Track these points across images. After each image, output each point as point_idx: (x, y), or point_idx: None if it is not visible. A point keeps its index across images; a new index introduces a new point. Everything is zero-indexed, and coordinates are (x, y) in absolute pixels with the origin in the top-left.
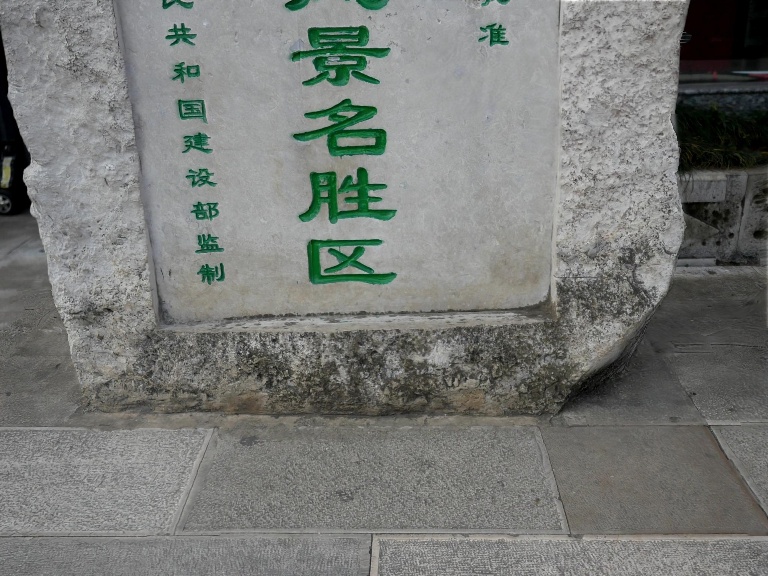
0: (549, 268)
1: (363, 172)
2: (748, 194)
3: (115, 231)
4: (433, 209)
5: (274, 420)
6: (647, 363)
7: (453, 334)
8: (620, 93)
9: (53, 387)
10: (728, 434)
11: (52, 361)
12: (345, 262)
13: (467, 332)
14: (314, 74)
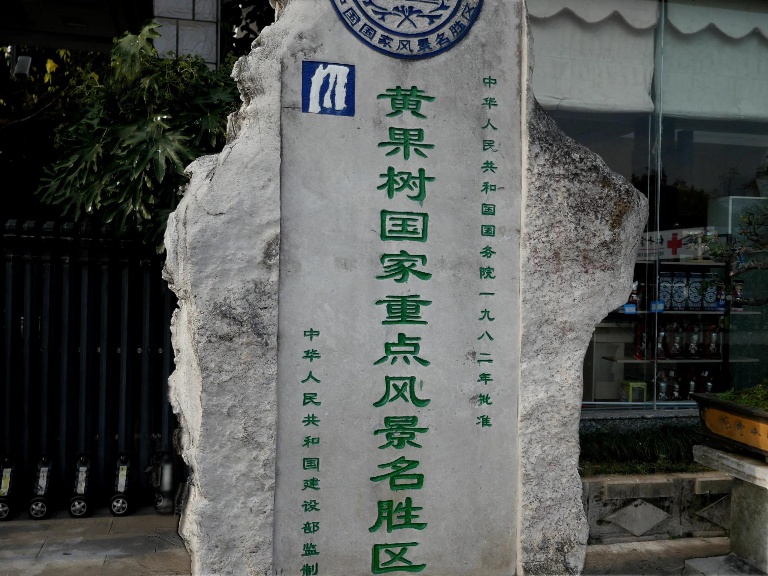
0: (515, 556)
1: (409, 500)
2: (590, 495)
3: (253, 544)
4: (449, 522)
5: None
6: None
7: None
8: (551, 453)
9: None
10: None
11: None
12: (395, 558)
13: None
14: (385, 442)
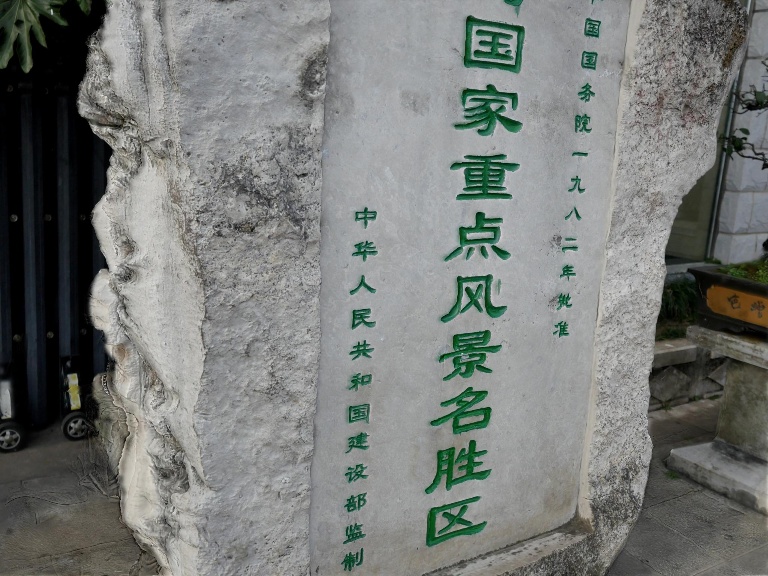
0: (577, 492)
1: (472, 443)
2: None
3: (285, 543)
4: (515, 464)
5: None
6: None
7: (540, 564)
8: (626, 363)
9: None
10: None
11: None
12: (453, 521)
13: (548, 560)
14: (452, 371)
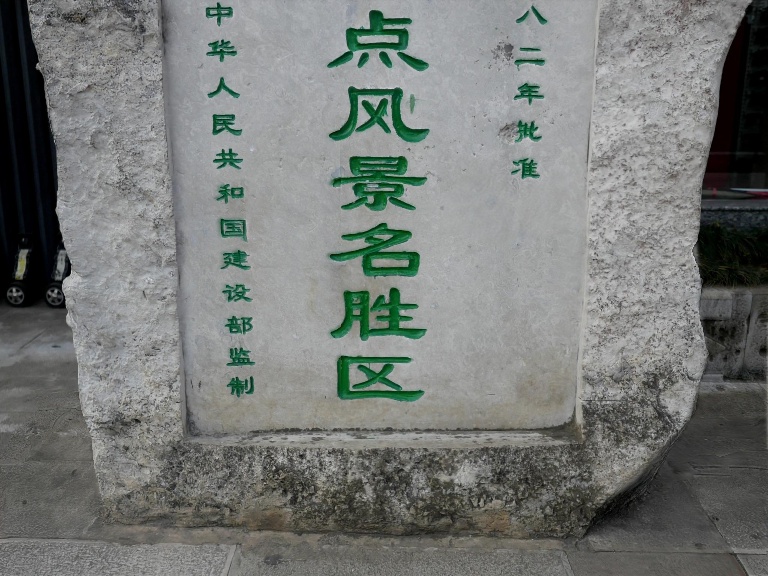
0: (574, 390)
1: (395, 292)
2: (753, 313)
3: (149, 343)
4: (462, 330)
5: (297, 537)
6: (668, 485)
7: (480, 454)
8: (645, 226)
9: (70, 495)
10: (755, 563)
11: (68, 467)
12: (374, 378)
13: (494, 452)
14: (353, 199)
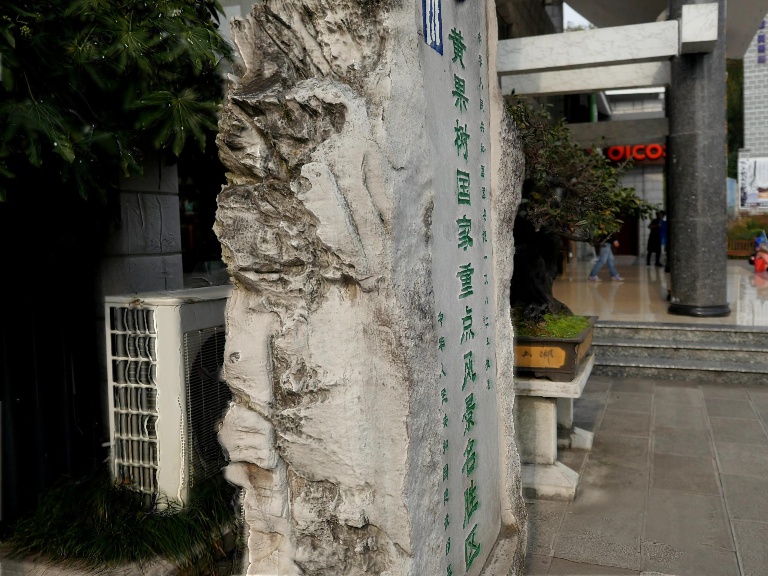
0: (500, 507)
1: (471, 483)
2: None
3: None
4: None
5: None
6: None
7: (513, 563)
8: None
9: None
10: None
11: None
12: None
13: None
14: None
